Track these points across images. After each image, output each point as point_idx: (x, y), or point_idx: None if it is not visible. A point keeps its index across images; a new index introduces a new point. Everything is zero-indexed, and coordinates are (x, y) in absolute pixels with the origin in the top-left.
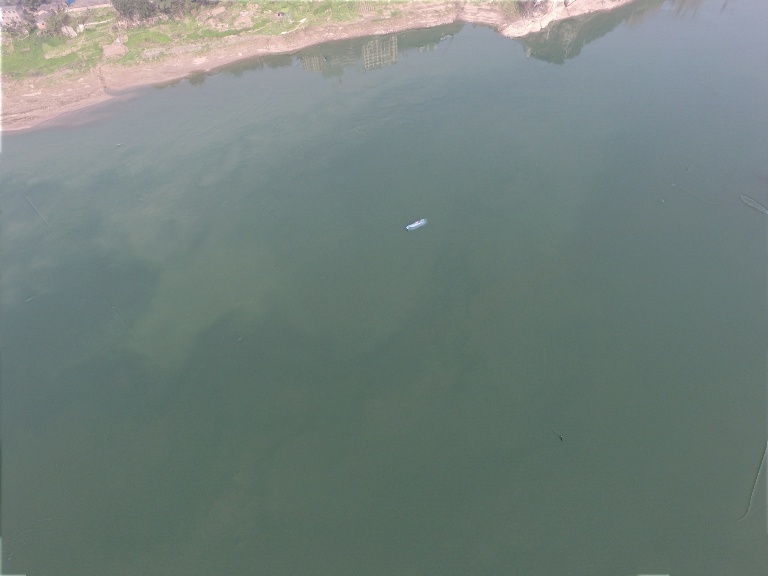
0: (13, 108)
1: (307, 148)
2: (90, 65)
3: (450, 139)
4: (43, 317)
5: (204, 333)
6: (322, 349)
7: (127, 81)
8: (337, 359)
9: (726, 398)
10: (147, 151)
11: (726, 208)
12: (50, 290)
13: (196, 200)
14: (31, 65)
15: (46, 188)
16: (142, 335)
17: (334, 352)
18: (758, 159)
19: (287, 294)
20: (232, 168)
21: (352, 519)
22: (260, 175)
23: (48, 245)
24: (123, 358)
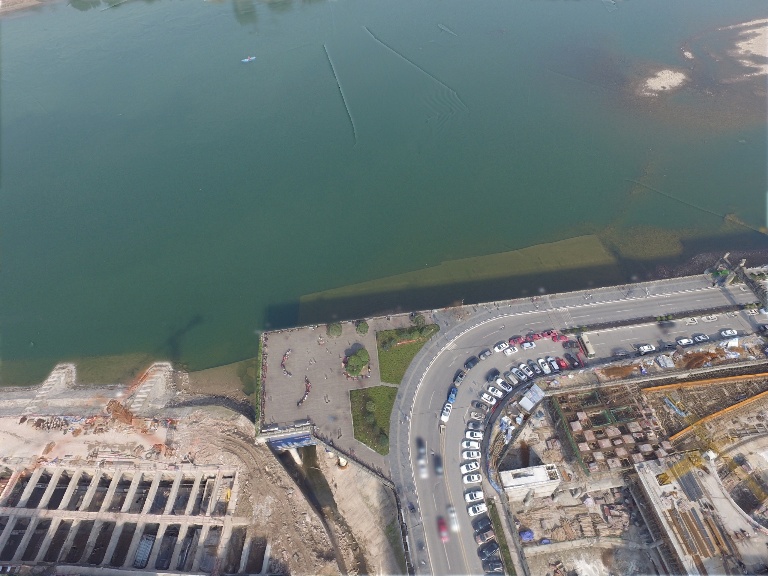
0: None
1: (184, 27)
2: None
3: (291, 23)
4: None
5: (97, 113)
6: (172, 116)
7: None
8: (180, 119)
9: None
10: (66, 32)
11: (452, 46)
12: None
13: (100, 57)
14: None
15: None
16: (57, 116)
17: (179, 117)
18: (486, 22)
19: (154, 95)
20: (128, 39)
21: (172, 172)
22: (148, 43)
23: None
24: (43, 125)
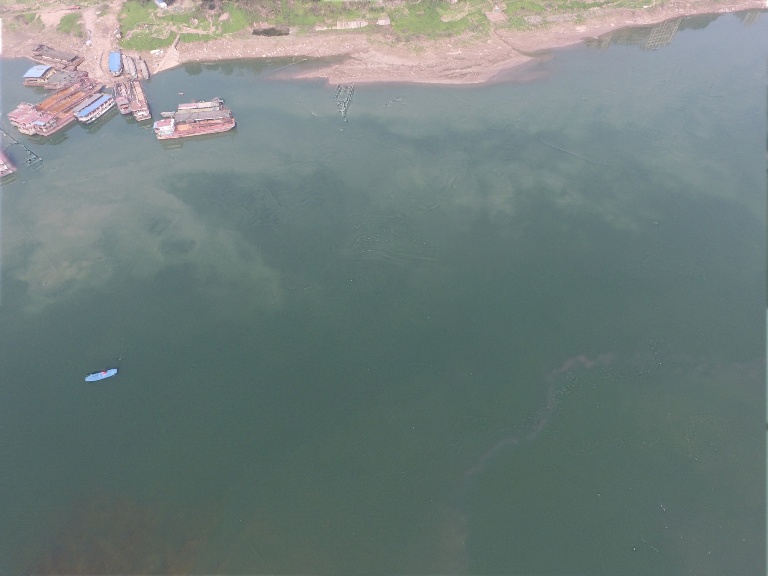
0: (450, 64)
1: None
2: (486, 29)
3: None
4: (721, 233)
5: None
6: None
7: (531, 44)
8: None
9: None
10: (615, 105)
11: None
12: (665, 216)
13: (708, 147)
14: (433, 27)
15: (550, 134)
16: None
17: None
18: None
19: None
20: (716, 121)
21: None
22: (746, 128)
23: (621, 179)
24: None
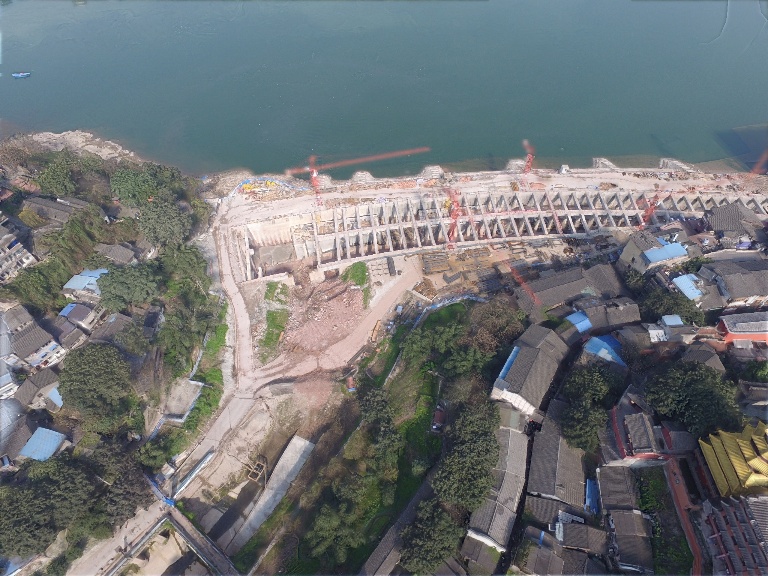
0: None
1: None
2: None
3: None
4: (381, 16)
5: (459, 26)
6: (522, 28)
7: None
8: None
9: (717, 36)
10: None
11: None
12: None
13: None
14: None
15: None
16: (427, 28)
17: (529, 28)
18: None
19: (494, 15)
20: None
21: (562, 60)
22: None
23: (350, 4)
24: None
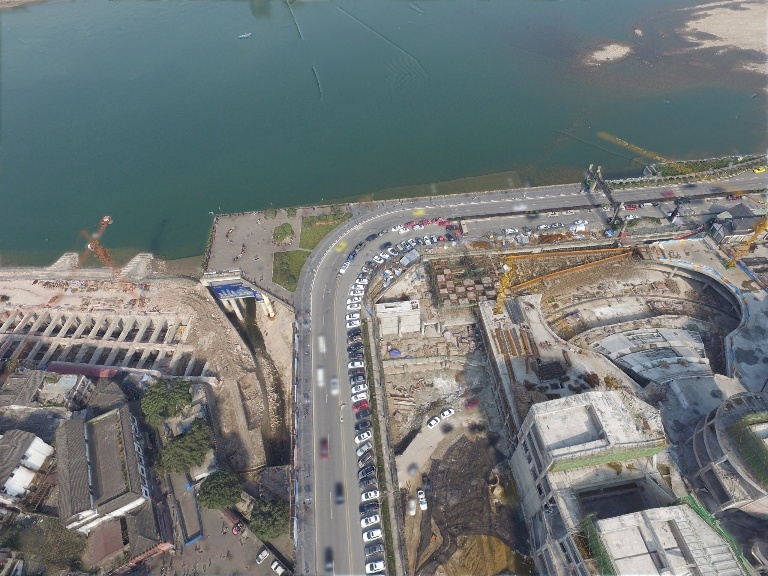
0: None
1: (194, 10)
2: None
3: None
4: (25, 68)
5: (113, 78)
6: (175, 80)
7: None
8: (181, 82)
9: None
10: (93, 15)
11: (426, 25)
12: None
13: (120, 34)
14: None
15: (28, 33)
16: (79, 80)
17: (180, 81)
18: (460, 5)
19: (162, 64)
20: (145, 20)
21: (169, 121)
22: (162, 23)
23: (29, 52)
24: (68, 86)
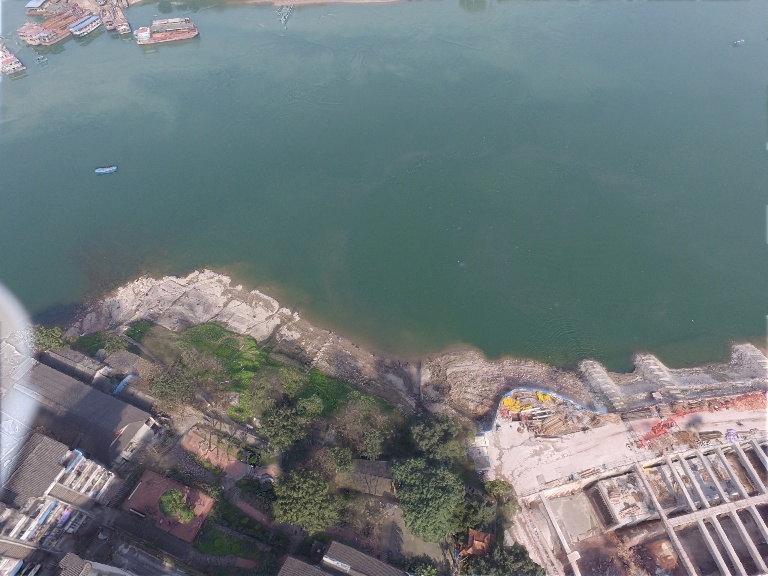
0: None
1: (619, 9)
2: None
3: (710, 7)
4: (549, 79)
5: (645, 91)
6: (728, 95)
7: None
8: (743, 98)
9: None
10: (500, 13)
11: None
12: (518, 77)
13: (564, 37)
14: None
15: (446, 33)
16: (604, 94)
17: (737, 96)
18: None
19: (681, 75)
20: (574, 20)
21: None
22: (597, 24)
23: (491, 57)
24: (607, 101)
